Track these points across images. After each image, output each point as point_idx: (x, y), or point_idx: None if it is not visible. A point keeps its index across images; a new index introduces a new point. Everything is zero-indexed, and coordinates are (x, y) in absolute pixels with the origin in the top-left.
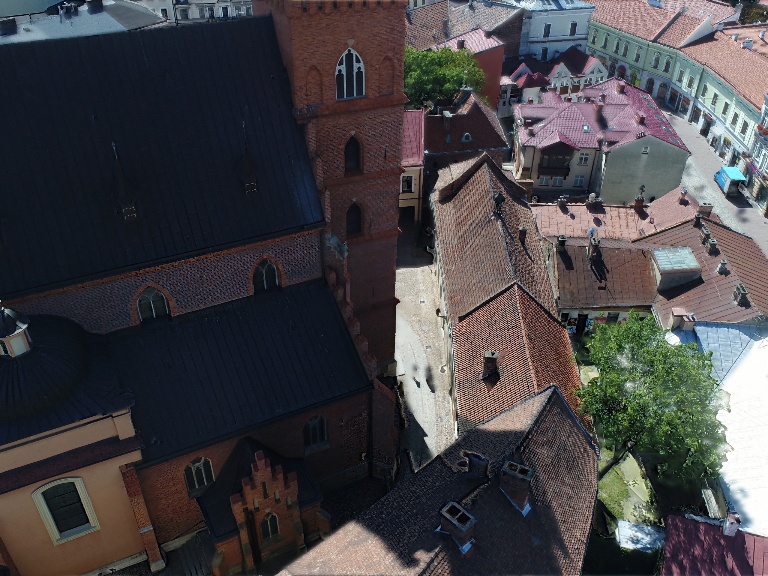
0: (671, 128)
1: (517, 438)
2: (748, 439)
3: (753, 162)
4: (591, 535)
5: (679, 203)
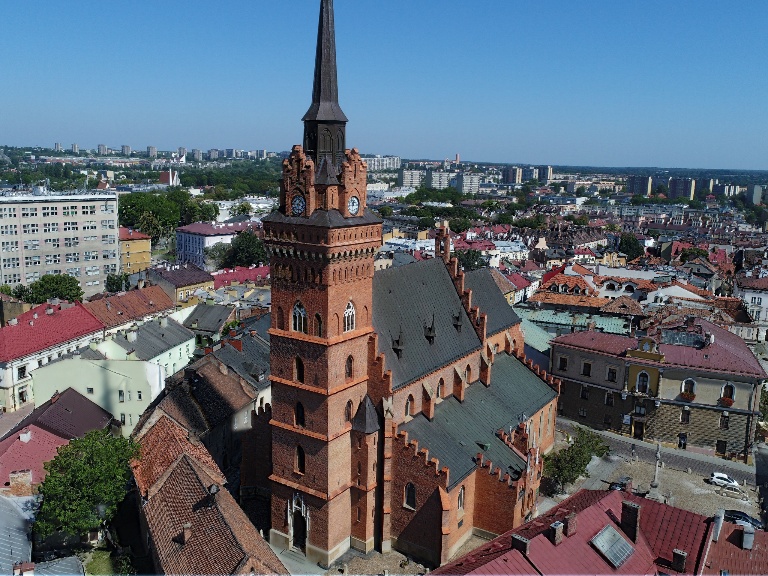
0: None
1: None
2: (1, 547)
3: None
4: (123, 504)
5: None
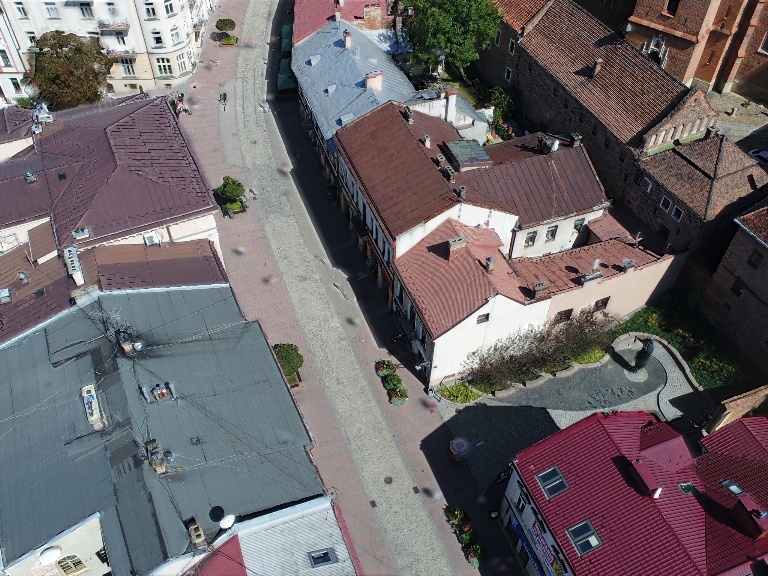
0: (583, 568)
1: None
2: None
3: None
4: None
5: None
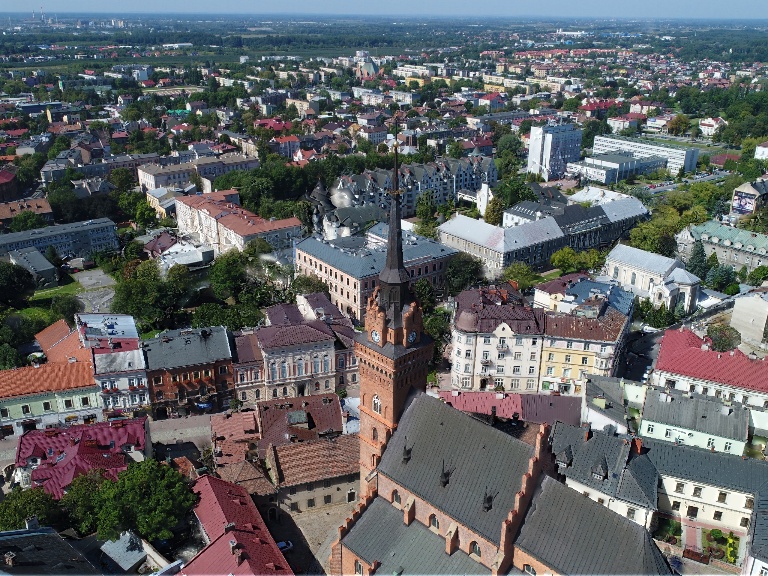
0: None
1: (478, 414)
2: None
3: (115, 409)
4: None
5: (227, 419)
